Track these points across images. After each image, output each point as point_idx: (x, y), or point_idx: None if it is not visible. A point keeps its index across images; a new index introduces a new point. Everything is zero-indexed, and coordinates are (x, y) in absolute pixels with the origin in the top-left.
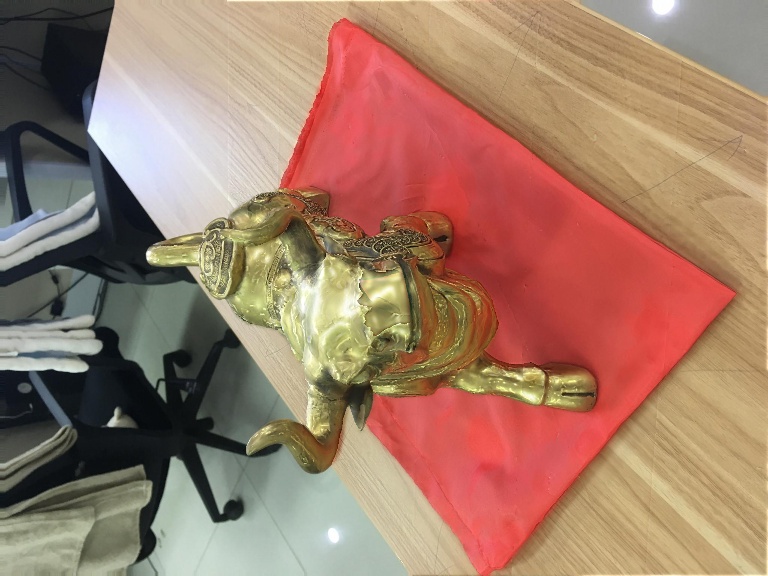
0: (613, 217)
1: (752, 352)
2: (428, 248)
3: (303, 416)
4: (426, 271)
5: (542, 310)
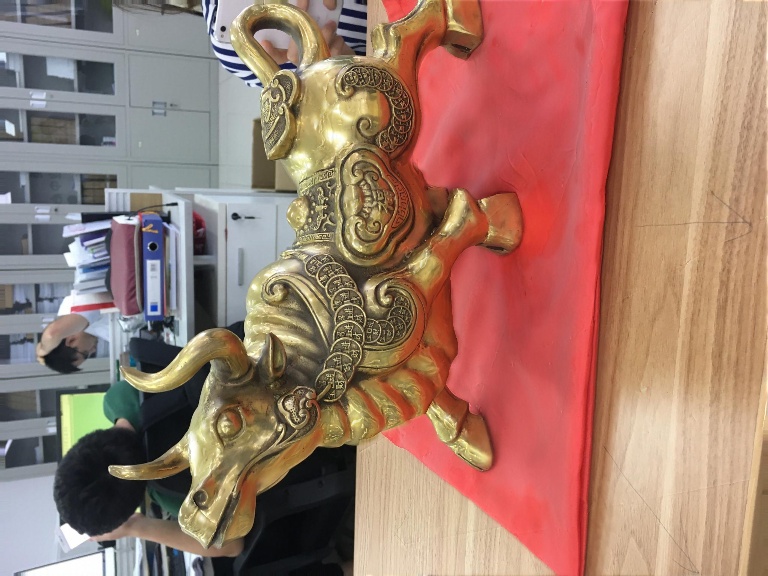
0: (577, 454)
1: None
2: (391, 353)
3: None
4: (368, 376)
5: (507, 391)
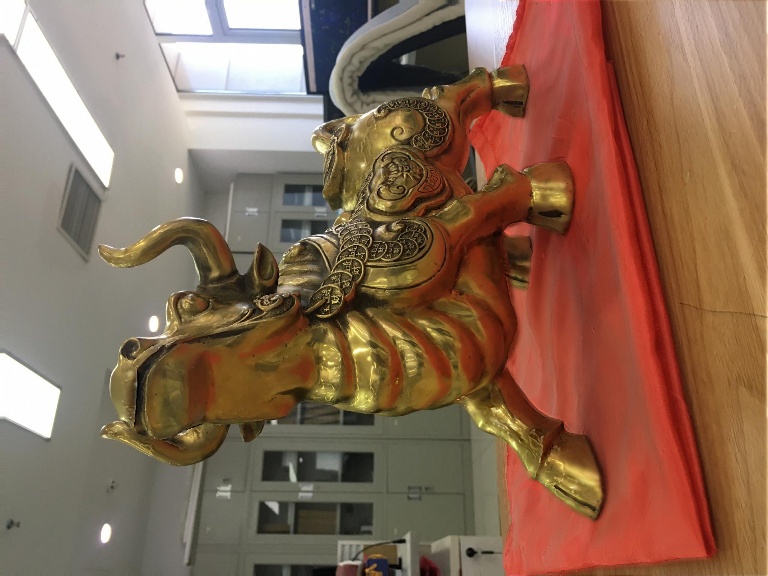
0: (642, 323)
1: None
2: (400, 271)
3: None
4: (377, 302)
5: (597, 370)
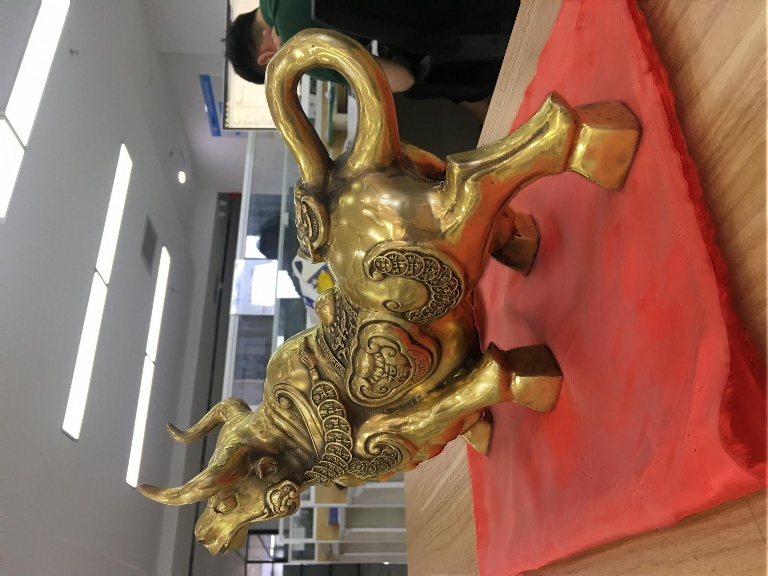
0: None
1: None
2: None
3: (516, 33)
4: None
5: None
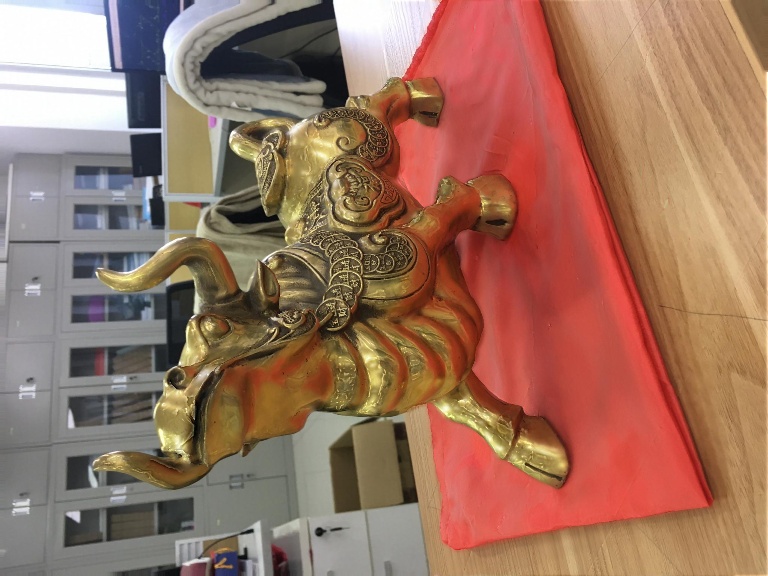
0: (631, 324)
1: (703, 571)
2: (395, 282)
3: None
4: (376, 312)
5: (555, 361)
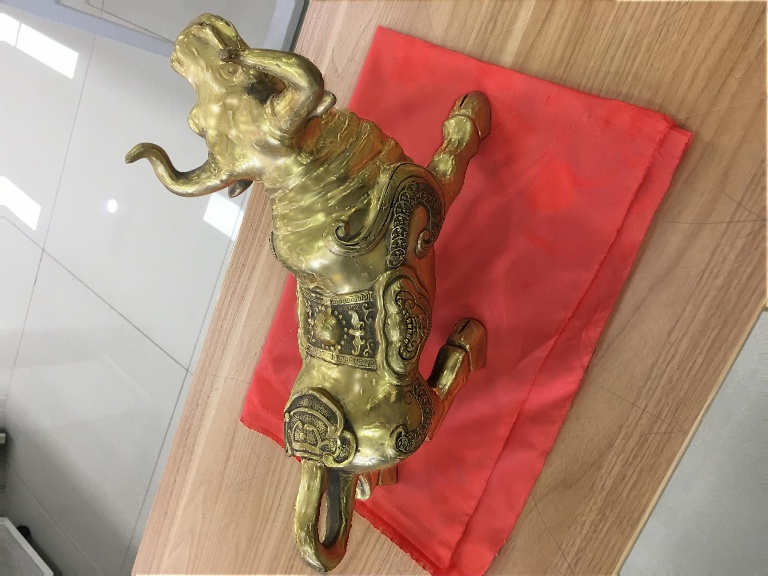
0: None
1: (413, 4)
2: None
3: (638, 497)
4: None
5: (422, 164)
